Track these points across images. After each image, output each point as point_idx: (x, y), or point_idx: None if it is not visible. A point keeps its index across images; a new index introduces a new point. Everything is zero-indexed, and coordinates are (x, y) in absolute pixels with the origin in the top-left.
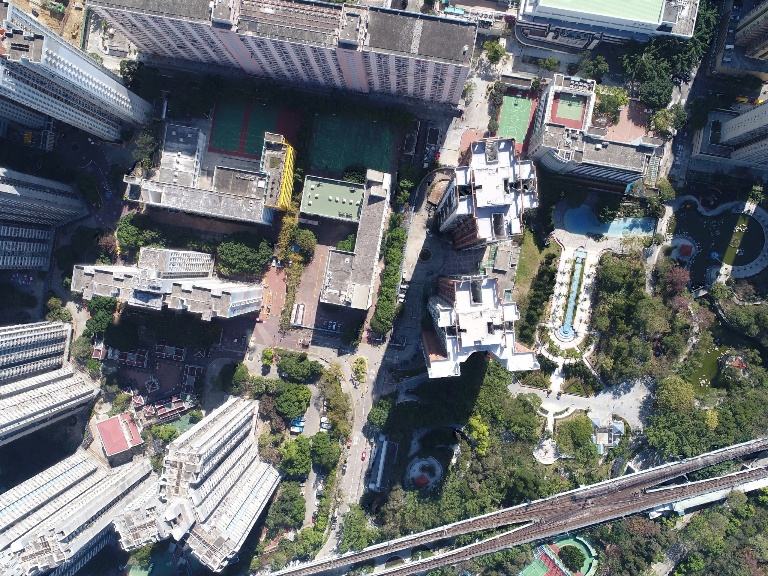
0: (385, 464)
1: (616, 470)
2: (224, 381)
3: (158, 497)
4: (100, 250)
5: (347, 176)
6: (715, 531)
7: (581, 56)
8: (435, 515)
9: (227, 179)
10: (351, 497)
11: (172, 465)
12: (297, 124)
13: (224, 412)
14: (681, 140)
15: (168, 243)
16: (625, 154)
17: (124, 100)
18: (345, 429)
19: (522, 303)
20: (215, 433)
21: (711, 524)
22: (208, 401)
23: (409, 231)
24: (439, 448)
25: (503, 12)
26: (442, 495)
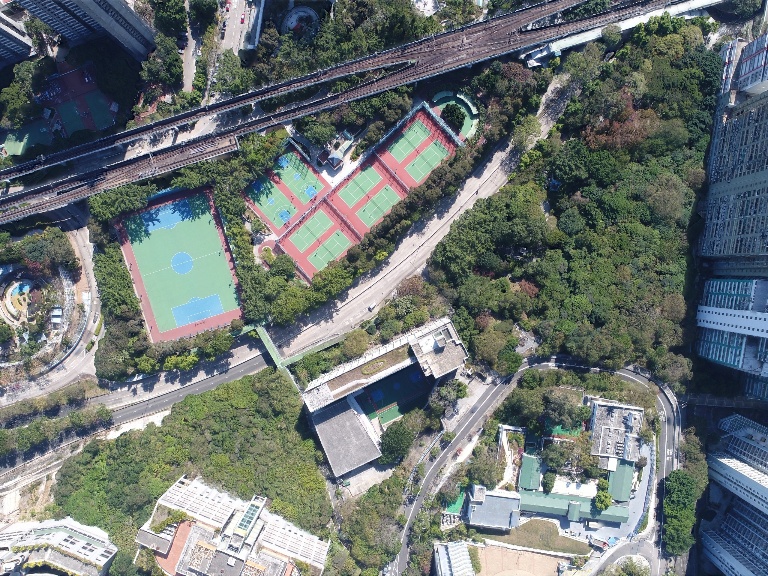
0: None
1: None
2: None
3: None
4: None
5: None
6: (588, 57)
7: None
8: (310, 55)
9: None
10: None
11: None
12: None
13: None
14: None
15: None
16: None
17: None
18: None
19: None
20: None
21: (585, 53)
22: None
23: None
24: (317, 1)
25: None
26: (316, 34)
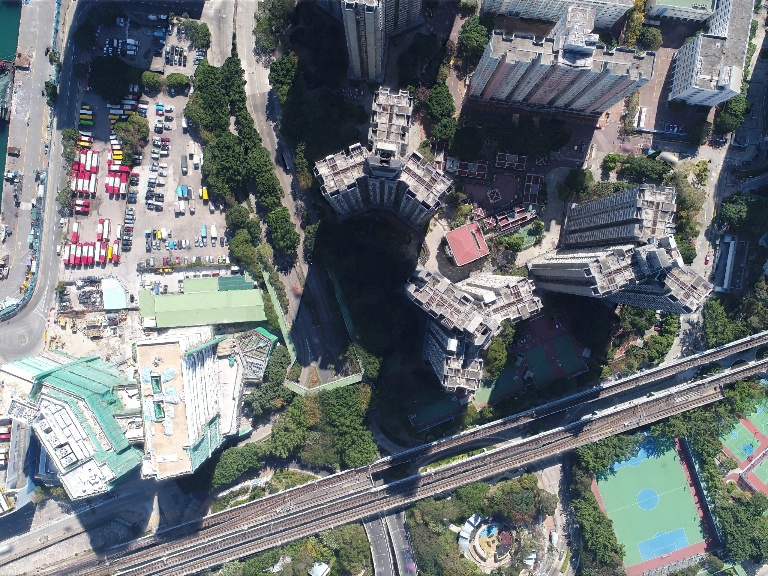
0: (734, 264)
1: None
2: (570, 187)
3: None
4: (443, 55)
5: None
6: None
7: None
8: None
9: None
10: None
11: (648, 205)
12: None
13: None
14: None
15: None
16: None
17: None
18: None
19: None
20: None
21: None
22: (546, 212)
23: None
24: None
25: None
26: None
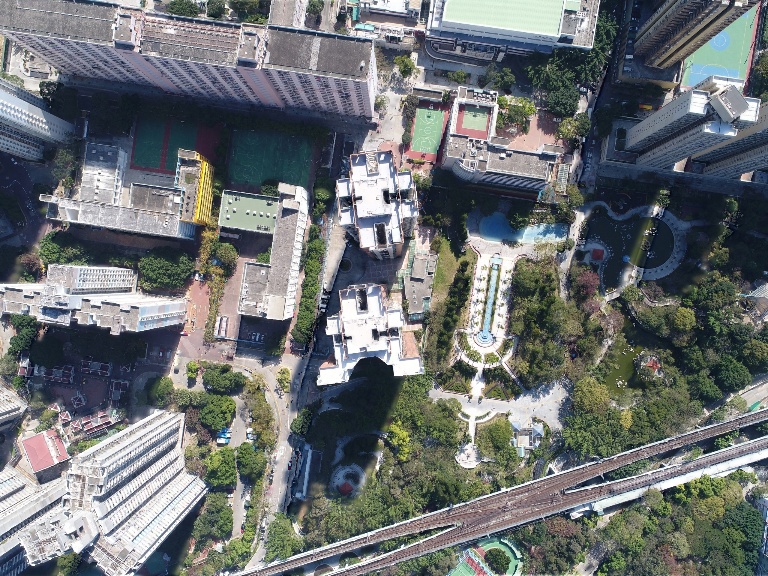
0: (310, 473)
1: (537, 472)
2: (149, 395)
3: (65, 511)
4: (23, 268)
5: (264, 190)
6: (632, 529)
7: (487, 68)
8: (358, 522)
9: (143, 195)
10: (279, 507)
11: (75, 479)
12: (217, 140)
13: (145, 425)
14: (590, 147)
15: (90, 260)
16: (529, 162)
17: (39, 121)
18: (270, 439)
19: (439, 310)
20: (125, 446)
21: (628, 523)
22: (135, 415)
23: (328, 242)
24: (363, 455)
25: (412, 27)
26: (364, 502)
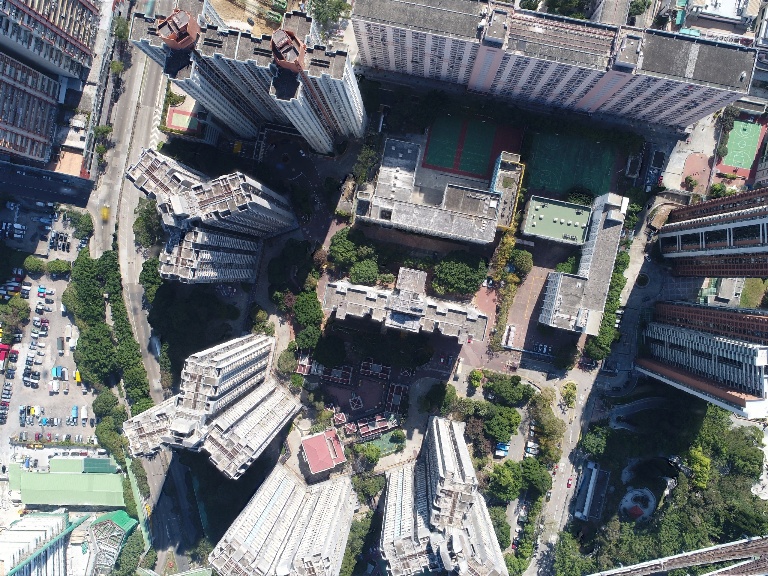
0: (595, 493)
1: None
2: (431, 401)
3: (423, 525)
4: (312, 264)
5: (573, 198)
6: None
7: None
8: (652, 548)
9: (458, 198)
10: (554, 524)
11: (447, 494)
12: (515, 142)
13: None
14: None
15: (382, 259)
16: None
17: (360, 114)
18: (555, 455)
19: None
20: None
21: None
22: (410, 421)
23: None
24: None
25: (740, 35)
26: (661, 528)
